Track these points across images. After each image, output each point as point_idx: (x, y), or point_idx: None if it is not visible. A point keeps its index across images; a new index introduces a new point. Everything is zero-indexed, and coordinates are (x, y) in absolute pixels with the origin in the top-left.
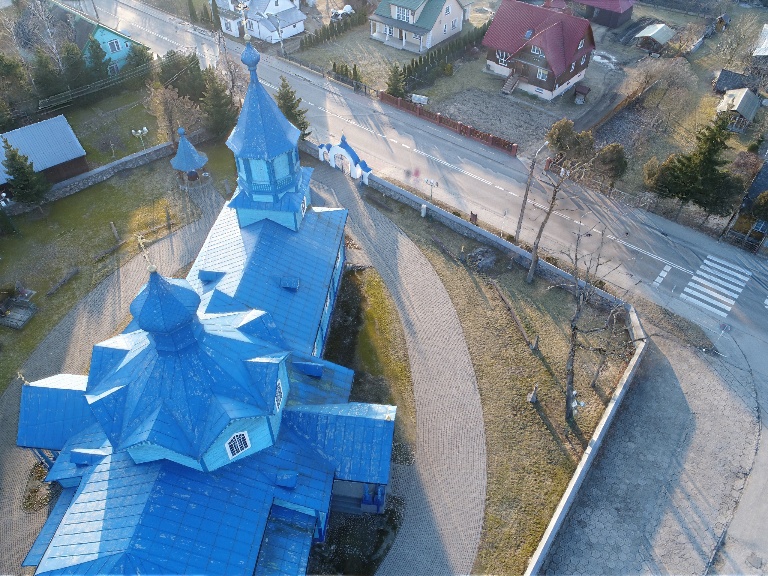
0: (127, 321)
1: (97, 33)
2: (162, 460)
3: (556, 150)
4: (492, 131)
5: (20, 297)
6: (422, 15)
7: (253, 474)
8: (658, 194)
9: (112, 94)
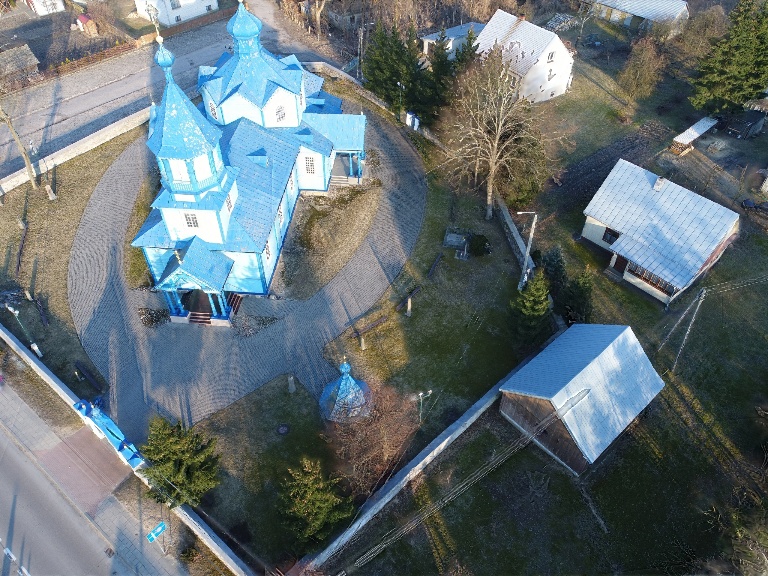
0: (360, 237)
1: None
2: None
3: None
4: None
5: None
6: None
7: None
8: None
9: None
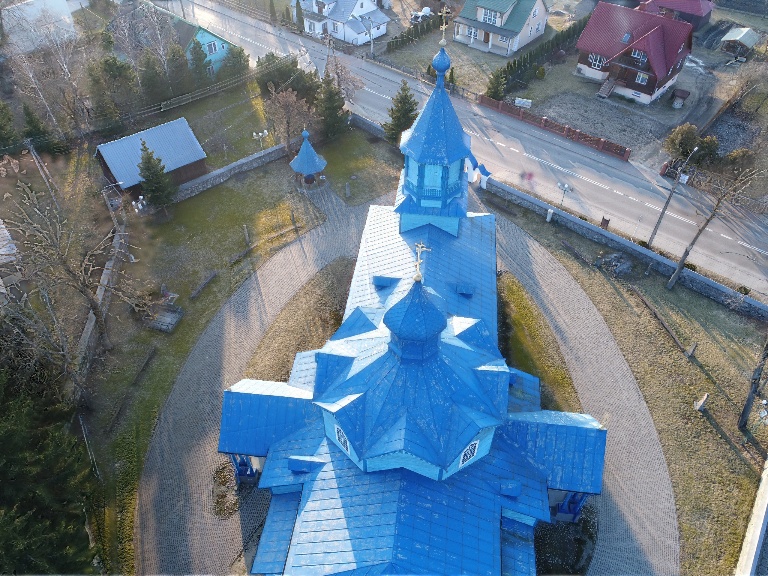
0: (276, 325)
1: (198, 35)
2: (400, 469)
3: (676, 155)
4: (597, 135)
5: (164, 300)
6: (510, 18)
7: (479, 483)
8: None
9: (210, 96)
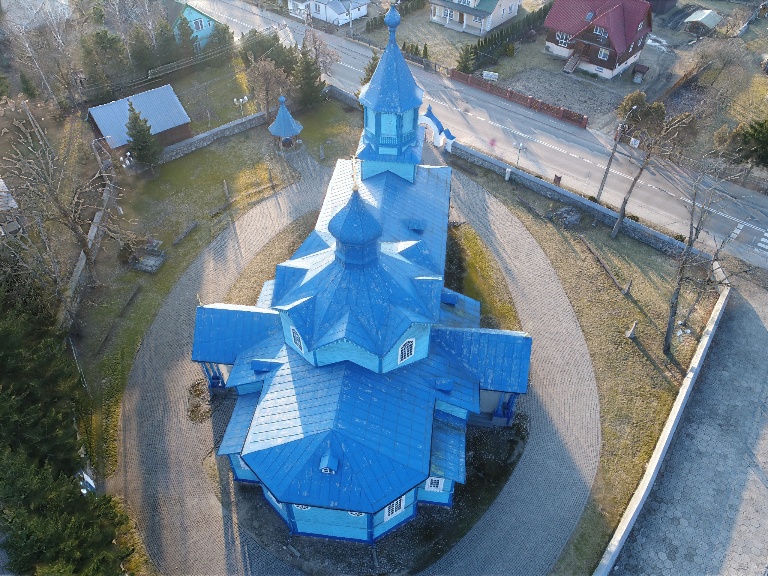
0: (250, 267)
1: (185, 12)
2: (345, 361)
3: (627, 121)
4: (559, 106)
5: (149, 246)
6: None
7: (416, 378)
8: (728, 159)
9: (197, 70)
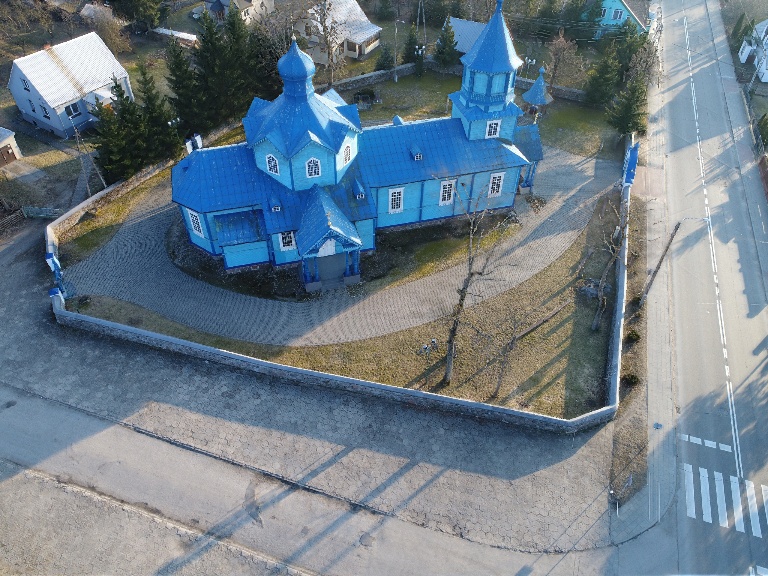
0: None
1: None
2: None
3: None
4: None
5: (374, 100)
6: None
7: (268, 188)
8: None
9: (583, 47)
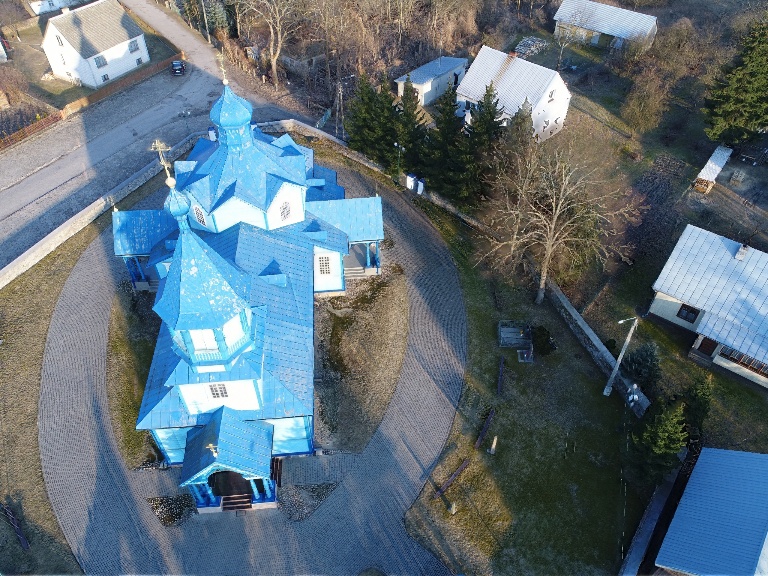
0: (401, 347)
1: None
2: None
3: None
4: None
5: None
6: None
7: None
8: None
9: None
